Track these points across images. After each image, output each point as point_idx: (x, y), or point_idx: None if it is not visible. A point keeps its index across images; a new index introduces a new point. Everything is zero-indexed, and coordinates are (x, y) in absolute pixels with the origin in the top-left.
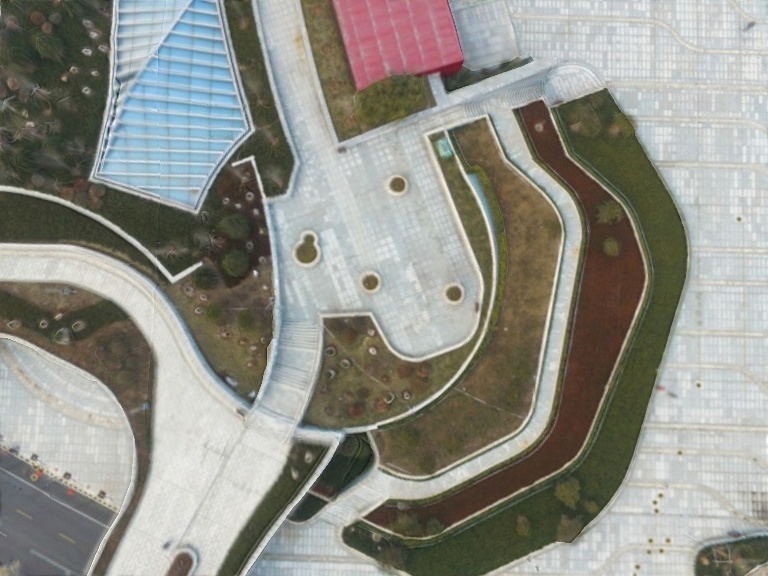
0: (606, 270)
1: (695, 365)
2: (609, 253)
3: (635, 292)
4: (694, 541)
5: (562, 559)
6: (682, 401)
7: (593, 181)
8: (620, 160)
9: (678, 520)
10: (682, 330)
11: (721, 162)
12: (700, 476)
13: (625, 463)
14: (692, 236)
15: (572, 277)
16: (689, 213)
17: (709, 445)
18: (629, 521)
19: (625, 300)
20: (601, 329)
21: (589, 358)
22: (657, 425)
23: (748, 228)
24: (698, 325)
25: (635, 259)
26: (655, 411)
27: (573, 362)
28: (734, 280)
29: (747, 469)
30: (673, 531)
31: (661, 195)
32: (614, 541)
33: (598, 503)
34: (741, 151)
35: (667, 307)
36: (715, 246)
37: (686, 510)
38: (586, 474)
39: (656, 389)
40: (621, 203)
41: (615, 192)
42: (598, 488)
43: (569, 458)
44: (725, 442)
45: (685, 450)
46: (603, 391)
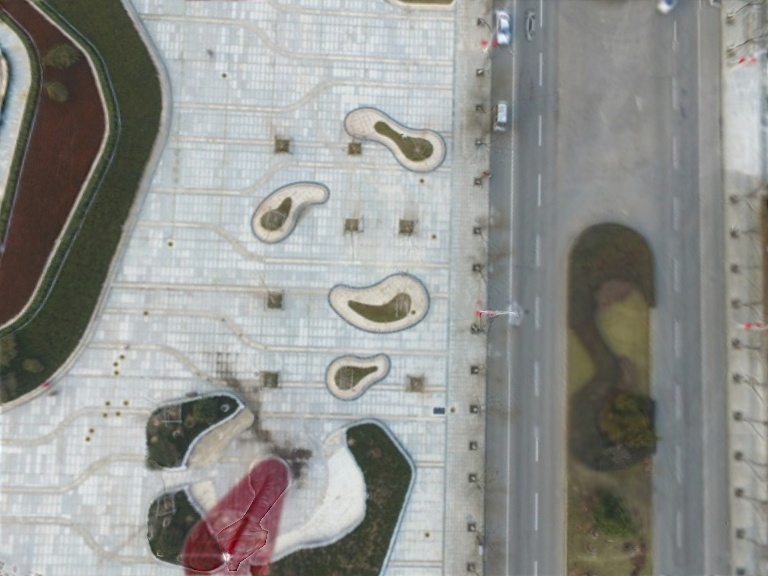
0: (59, 118)
1: (168, 223)
2: (50, 97)
3: (92, 142)
4: (153, 403)
5: (11, 424)
6: (152, 260)
7: (52, 26)
8: (89, 7)
9: (138, 382)
10: (157, 187)
11: (209, 17)
12: (165, 337)
13: (82, 322)
14: (174, 92)
15: (17, 123)
16: (172, 68)
17: (177, 305)
18: (87, 384)
19: (80, 150)
20: (51, 179)
21: (35, 209)
22: (124, 285)
23: (233, 85)
24: (174, 183)
25: (94, 108)
26: (123, 270)
27: (18, 213)
28: (215, 137)
29: (214, 329)
30: (132, 393)
31: (133, 45)
32: (69, 404)
33: (45, 363)
34: (231, 6)
35: (134, 161)
36: (197, 102)
37: (148, 372)
38: (34, 332)
39: (126, 248)
40: (83, 50)
41: (79, 39)
42: (49, 348)
43: (12, 315)
44: (194, 302)
45: (151, 310)
46: (53, 245)
